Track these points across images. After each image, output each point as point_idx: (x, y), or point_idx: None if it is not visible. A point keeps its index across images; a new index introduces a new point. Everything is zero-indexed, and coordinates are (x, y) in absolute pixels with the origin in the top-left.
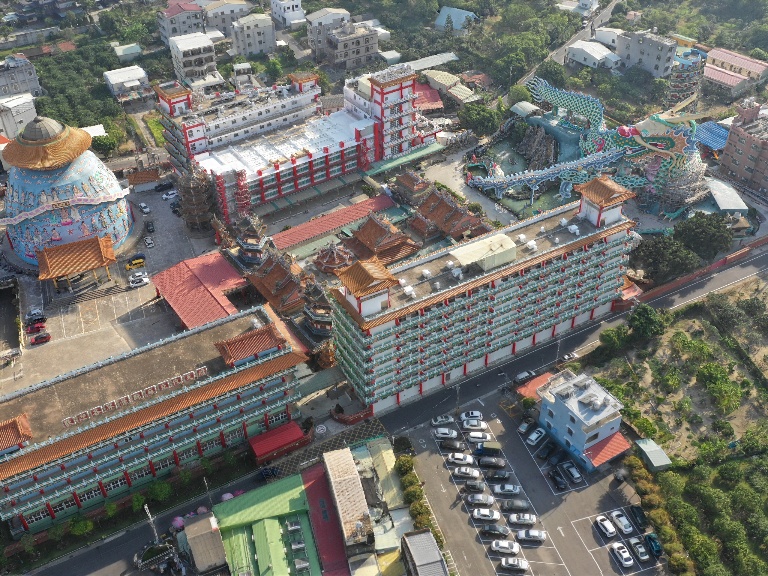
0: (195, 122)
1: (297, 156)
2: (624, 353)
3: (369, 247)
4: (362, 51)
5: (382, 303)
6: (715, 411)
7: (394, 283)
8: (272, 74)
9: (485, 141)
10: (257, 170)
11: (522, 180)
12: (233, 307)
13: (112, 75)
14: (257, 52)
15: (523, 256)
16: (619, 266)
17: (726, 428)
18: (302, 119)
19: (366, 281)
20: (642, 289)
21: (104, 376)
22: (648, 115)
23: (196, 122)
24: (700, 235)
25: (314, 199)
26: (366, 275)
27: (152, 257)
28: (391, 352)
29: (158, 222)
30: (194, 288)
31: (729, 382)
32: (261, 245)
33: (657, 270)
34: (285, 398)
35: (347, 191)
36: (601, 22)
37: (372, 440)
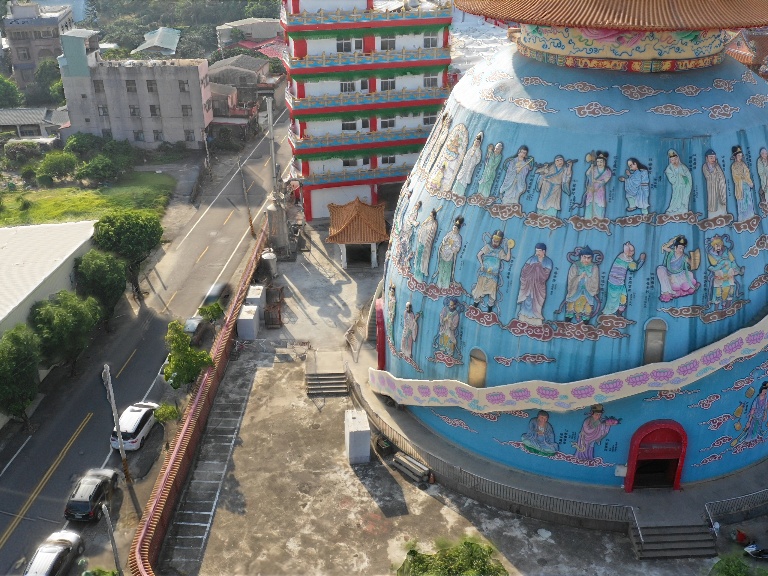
0: None
1: None
2: None
3: None
4: None
5: None
6: None
7: None
8: (5, 102)
9: None
10: None
11: None
12: None
13: None
14: None
15: None
16: None
17: None
18: None
19: None
20: None
21: None
22: None
23: None
24: None
25: None
26: None
27: None
28: None
29: None
30: None
31: None
32: None
33: None
34: None
35: None
36: None
37: None
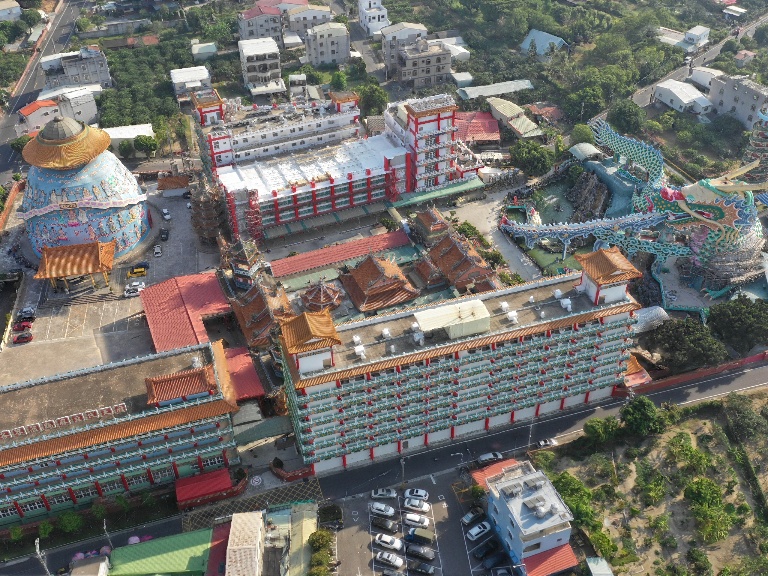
0: (222, 134)
1: (318, 180)
2: (612, 448)
3: (361, 288)
4: (433, 70)
5: (324, 361)
6: (696, 536)
7: (335, 343)
8: (335, 86)
9: (535, 182)
10: (272, 190)
11: (553, 232)
12: (205, 334)
13: (176, 74)
14: (329, 61)
15: (499, 327)
16: (620, 350)
17: (700, 561)
18: (339, 140)
19: (305, 337)
20: (654, 376)
21: (32, 396)
22: (725, 172)
23: (223, 134)
24: (735, 323)
25: (334, 225)
26: (307, 330)
27: (156, 267)
28: (332, 414)
29: (174, 231)
30: (175, 308)
31: (722, 504)
32: (252, 272)
33: (672, 358)
34: (219, 444)
35: (371, 220)
36: (705, 60)
37: (299, 504)
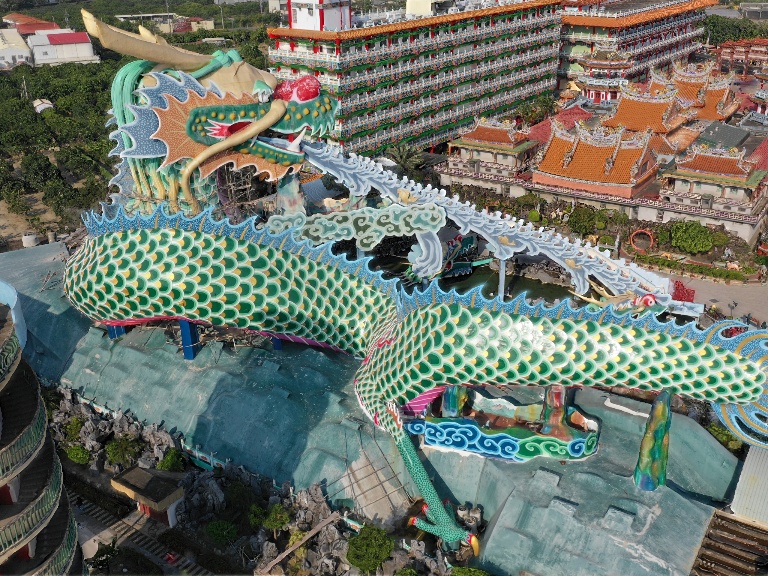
0: None
1: None
2: None
3: None
4: None
5: None
6: None
7: None
8: None
9: None
10: None
11: None
12: None
13: None
14: None
15: None
16: None
17: None
18: None
19: None
20: None
21: None
22: None
23: None
24: None
25: None
26: None
27: None
28: None
29: None
30: None
31: None
32: None
33: None
34: None
35: None
36: None
37: None
